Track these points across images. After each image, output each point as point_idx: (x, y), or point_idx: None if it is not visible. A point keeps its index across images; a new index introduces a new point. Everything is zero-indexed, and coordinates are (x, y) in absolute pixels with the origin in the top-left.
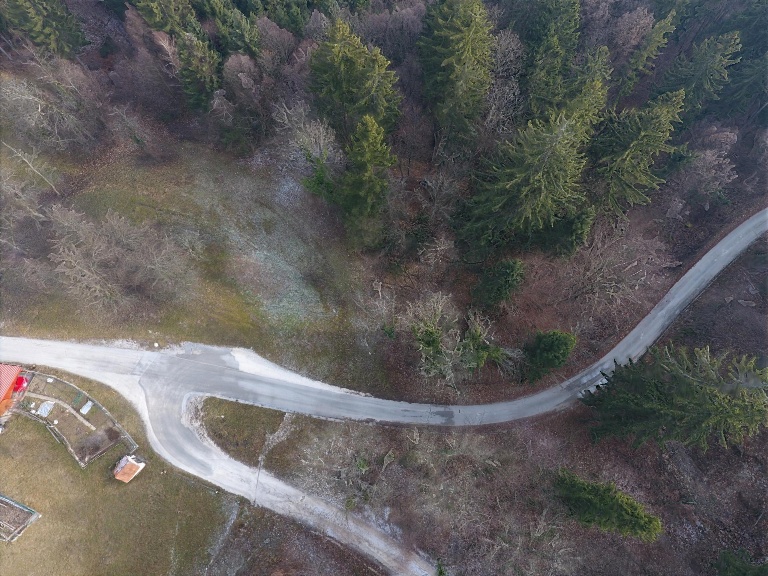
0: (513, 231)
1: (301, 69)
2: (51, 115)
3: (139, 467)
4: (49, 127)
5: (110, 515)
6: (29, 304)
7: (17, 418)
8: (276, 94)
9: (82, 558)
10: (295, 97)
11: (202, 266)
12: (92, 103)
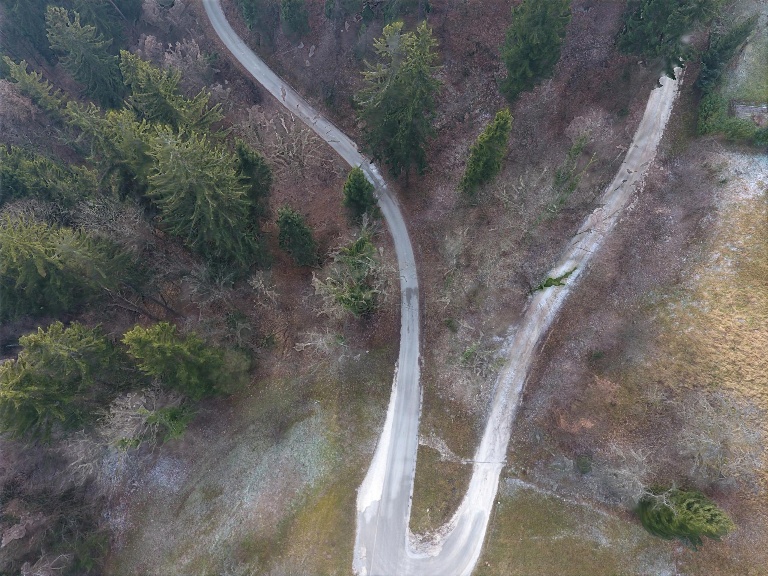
0: None
1: (7, 460)
2: None
3: None
4: None
5: None
6: None
7: None
8: None
9: None
10: None
11: (261, 568)
12: None
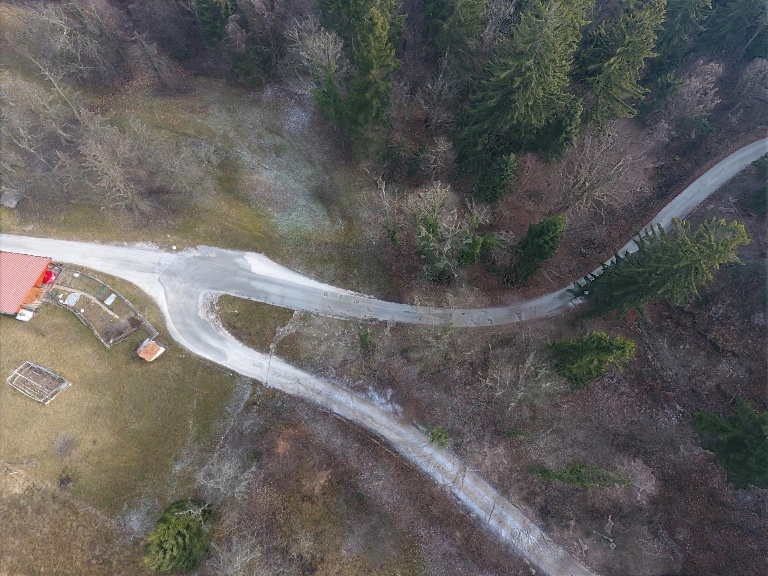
0: (508, 140)
1: None
2: (75, 41)
3: (160, 348)
4: (74, 50)
5: (134, 388)
6: (55, 211)
7: (47, 306)
8: (286, 28)
9: (109, 423)
10: (303, 37)
11: (216, 182)
12: (113, 33)
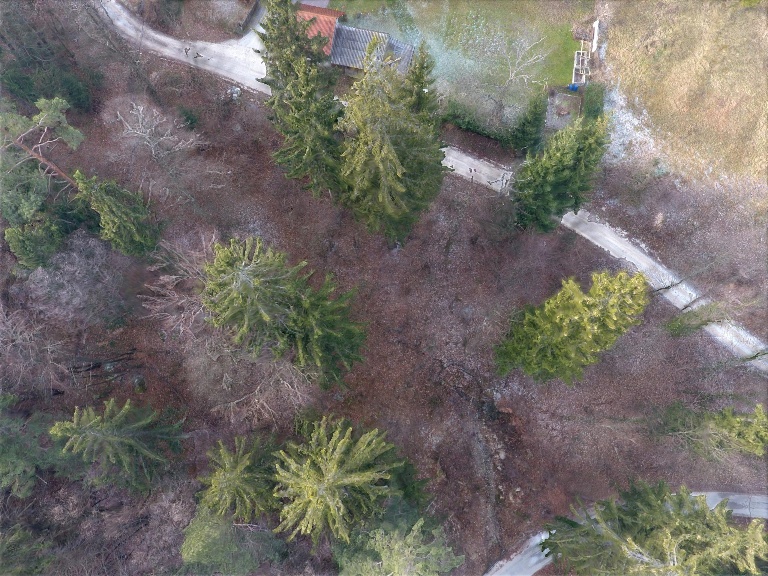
0: None
1: None
2: None
3: None
4: None
5: None
6: None
7: None
8: None
9: None
10: None
11: None
12: None
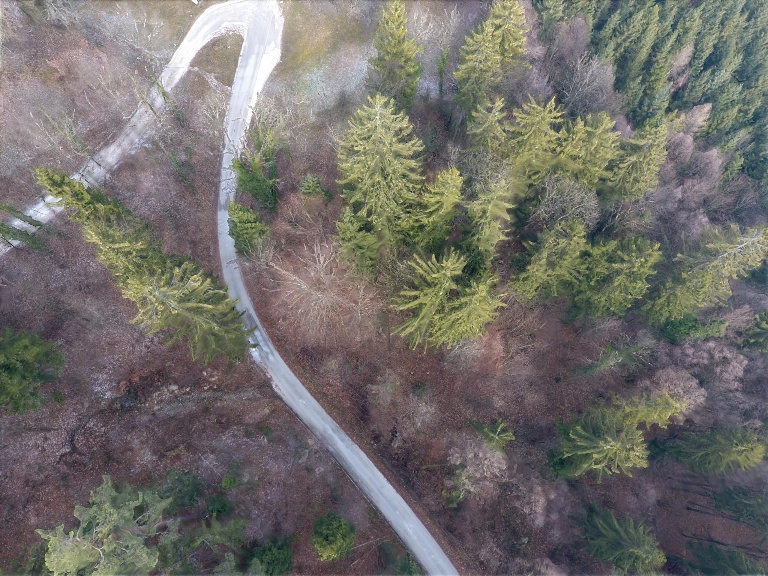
0: None
1: None
2: None
3: None
4: None
5: None
6: None
7: None
8: None
9: None
10: None
11: (350, 28)
12: None
